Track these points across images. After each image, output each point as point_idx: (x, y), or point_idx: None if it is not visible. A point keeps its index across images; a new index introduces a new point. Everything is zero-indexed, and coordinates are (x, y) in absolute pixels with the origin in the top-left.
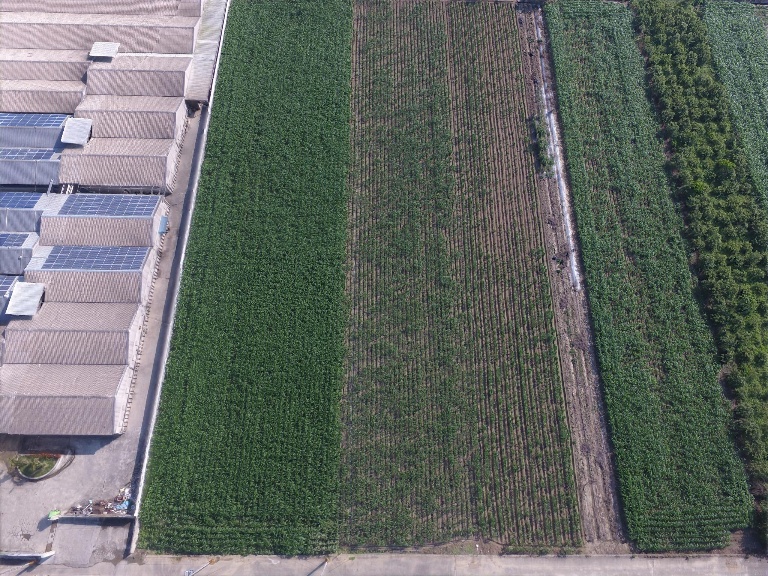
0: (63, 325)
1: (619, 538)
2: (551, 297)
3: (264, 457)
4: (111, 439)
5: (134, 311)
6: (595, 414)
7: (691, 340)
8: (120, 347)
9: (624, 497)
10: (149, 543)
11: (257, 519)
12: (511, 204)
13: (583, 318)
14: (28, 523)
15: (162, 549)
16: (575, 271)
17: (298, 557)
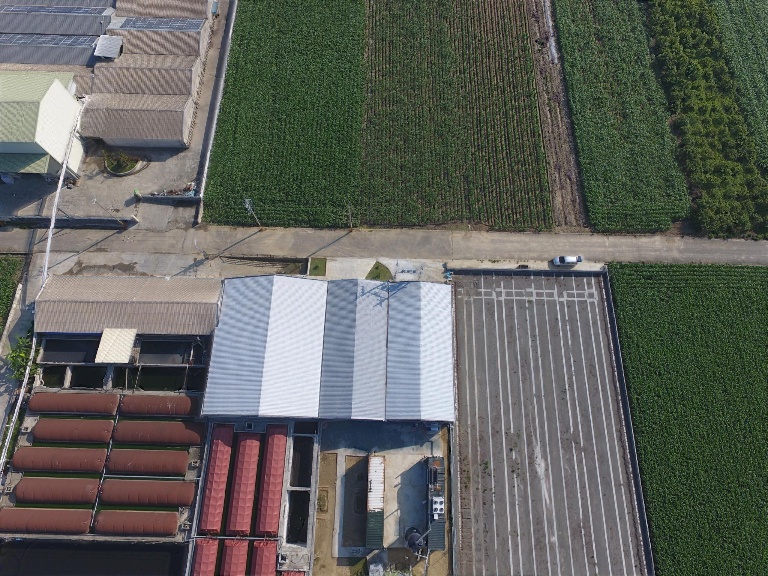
0: (139, 65)
1: (582, 224)
2: (533, 67)
3: (300, 164)
4: (178, 152)
5: (195, 59)
6: (566, 145)
7: (647, 96)
8: (185, 81)
9: (587, 195)
10: (212, 218)
11: (296, 203)
12: (502, 3)
13: (559, 82)
14: (117, 202)
15: (222, 222)
16: (554, 50)
17: (328, 229)
